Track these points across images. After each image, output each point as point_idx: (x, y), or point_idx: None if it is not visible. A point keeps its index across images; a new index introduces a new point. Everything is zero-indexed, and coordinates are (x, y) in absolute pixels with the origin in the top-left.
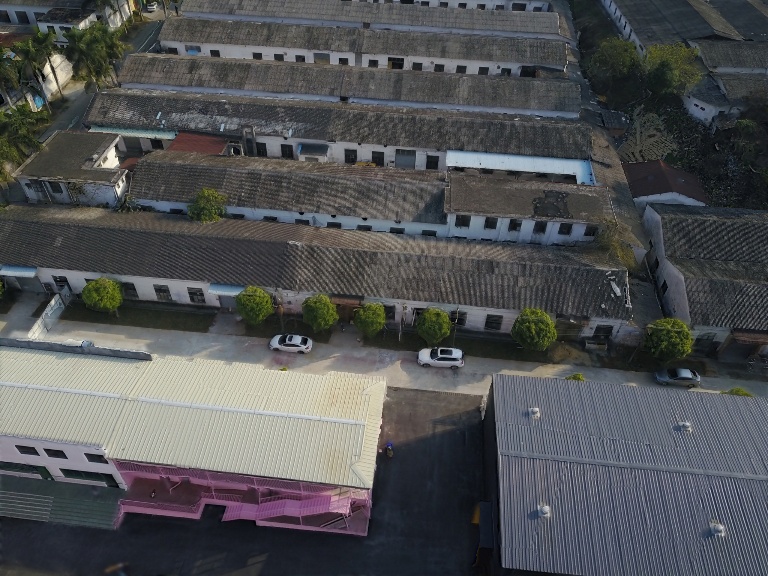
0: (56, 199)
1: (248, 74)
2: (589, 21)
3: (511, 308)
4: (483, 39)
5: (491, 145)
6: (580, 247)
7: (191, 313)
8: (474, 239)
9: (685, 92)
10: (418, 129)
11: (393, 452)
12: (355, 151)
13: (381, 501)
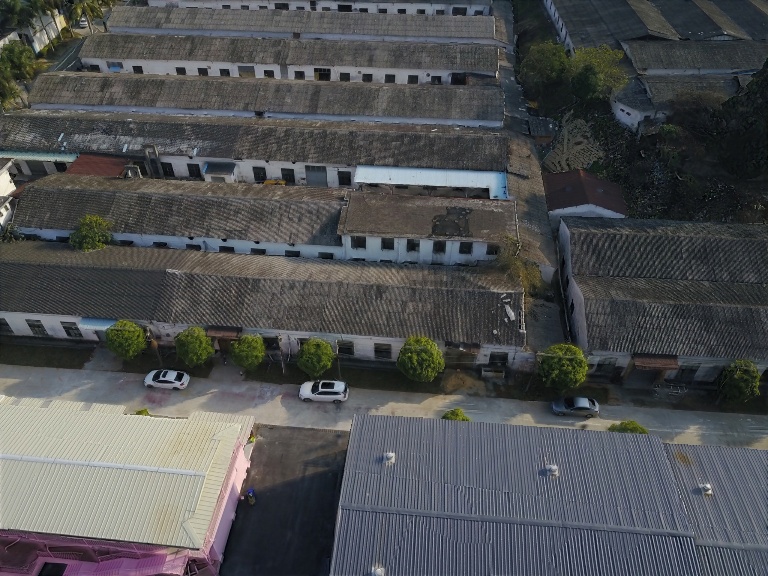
0: None
1: (161, 91)
2: (530, 24)
3: (397, 336)
4: (412, 46)
5: (403, 159)
6: (482, 267)
7: (69, 348)
8: (371, 261)
9: (611, 97)
10: (328, 144)
11: (256, 499)
12: (264, 169)
13: (234, 555)
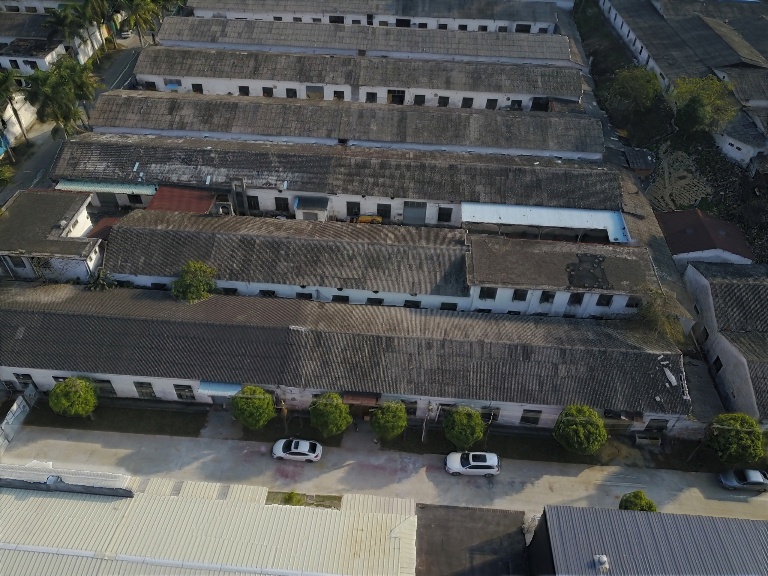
0: (18, 274)
1: (235, 114)
2: (599, 43)
3: (552, 404)
4: (490, 68)
5: (510, 195)
6: (622, 321)
7: (179, 411)
8: (501, 313)
9: (718, 130)
10: (428, 178)
11: None
12: (358, 203)
13: None
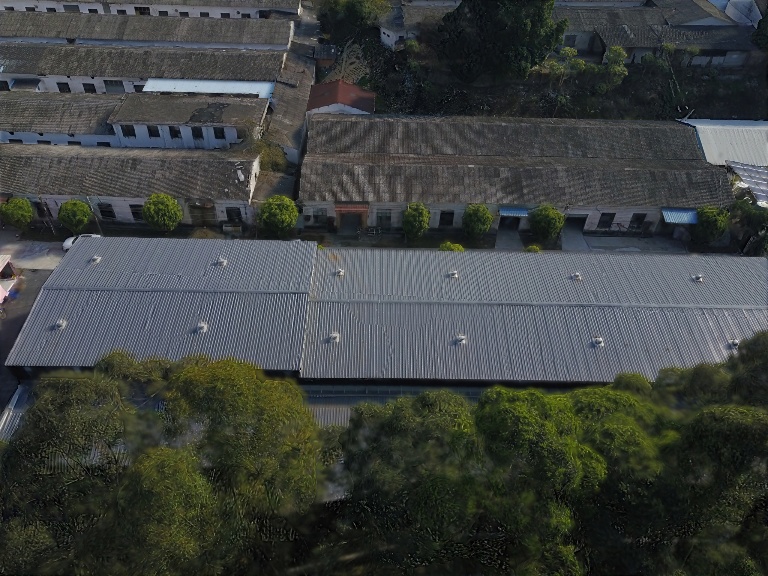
0: None
1: None
2: None
3: (144, 196)
4: None
5: (189, 72)
6: None
7: None
8: (140, 147)
9: (375, 22)
10: (124, 61)
11: (7, 315)
12: (67, 84)
13: None
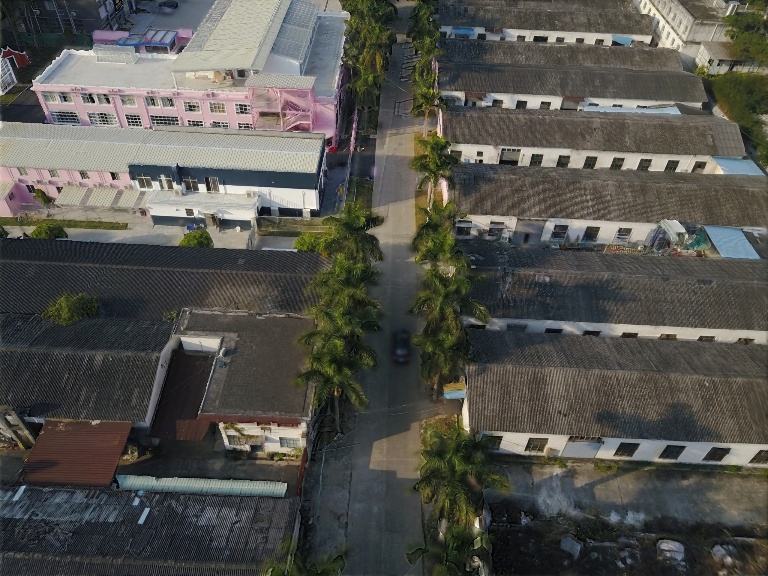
0: None
1: None
2: None
3: None
4: None
5: None
6: None
7: None
8: None
9: None
10: None
11: None
12: None
13: None
